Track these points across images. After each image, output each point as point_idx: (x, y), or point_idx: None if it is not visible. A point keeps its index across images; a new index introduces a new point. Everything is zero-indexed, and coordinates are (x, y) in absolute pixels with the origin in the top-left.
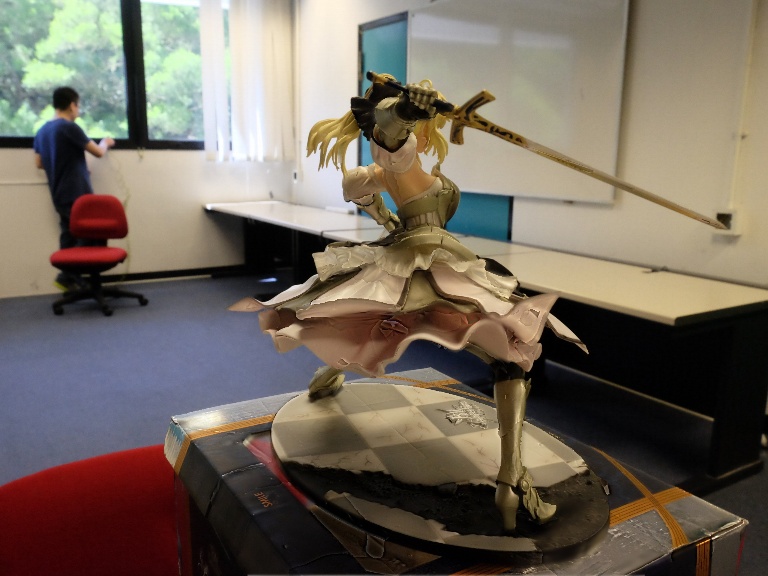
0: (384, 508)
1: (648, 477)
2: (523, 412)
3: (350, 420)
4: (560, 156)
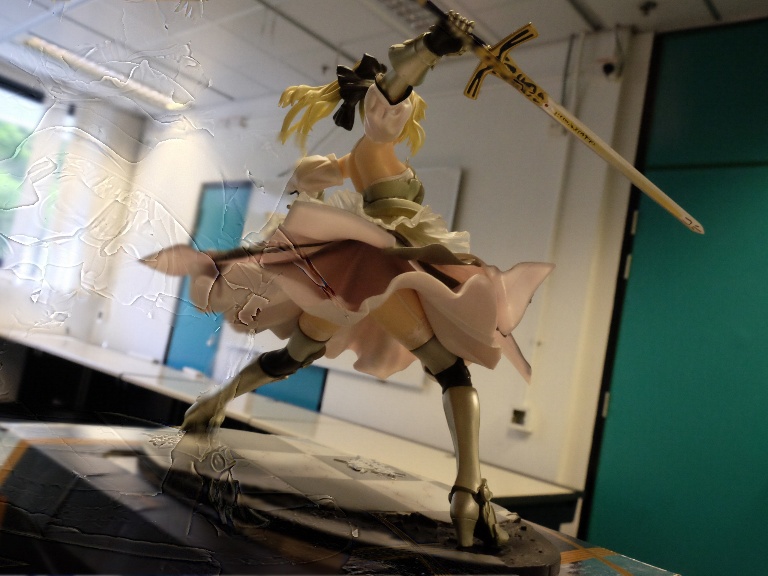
0: None
1: (415, 530)
2: (244, 374)
3: None
4: None
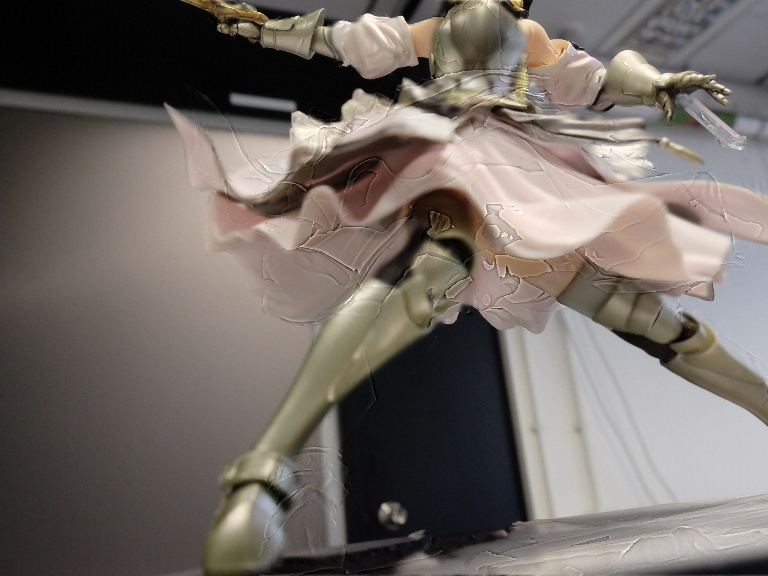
0: None
1: None
2: (408, 329)
3: (750, 498)
4: None
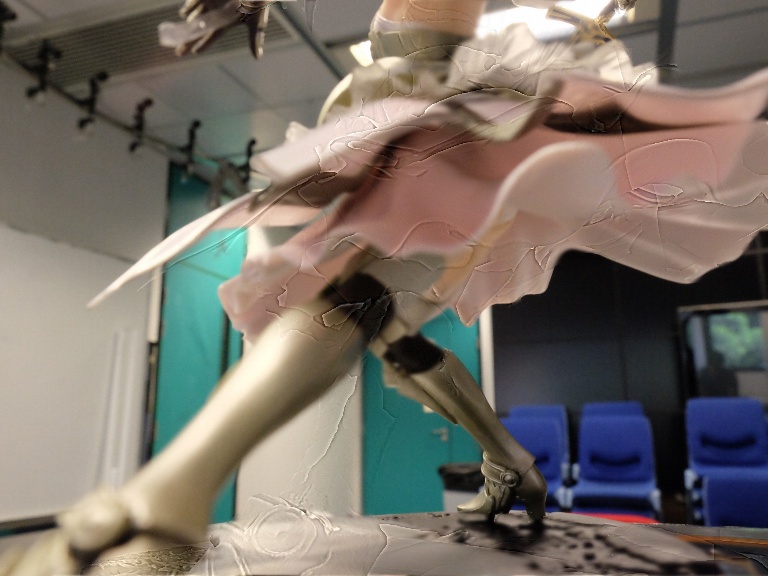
0: (662, 547)
1: None
2: None
3: None
4: None
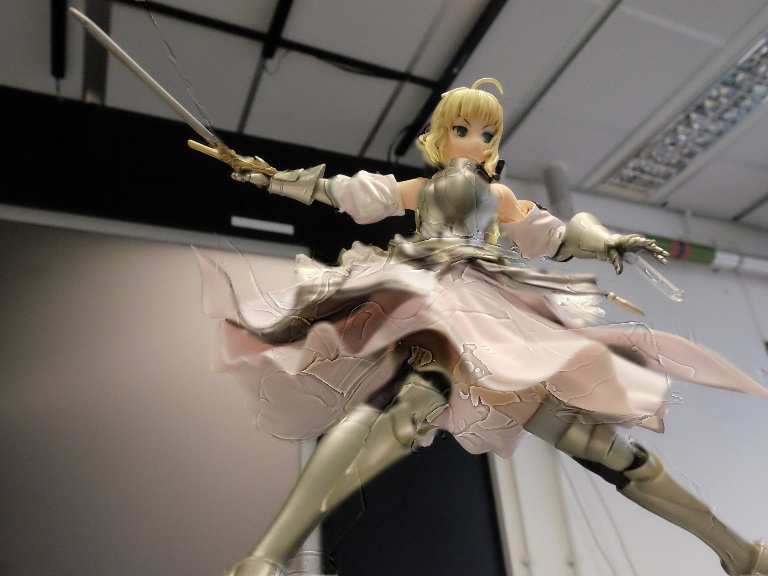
0: None
1: None
2: (395, 448)
3: None
4: (194, 106)
